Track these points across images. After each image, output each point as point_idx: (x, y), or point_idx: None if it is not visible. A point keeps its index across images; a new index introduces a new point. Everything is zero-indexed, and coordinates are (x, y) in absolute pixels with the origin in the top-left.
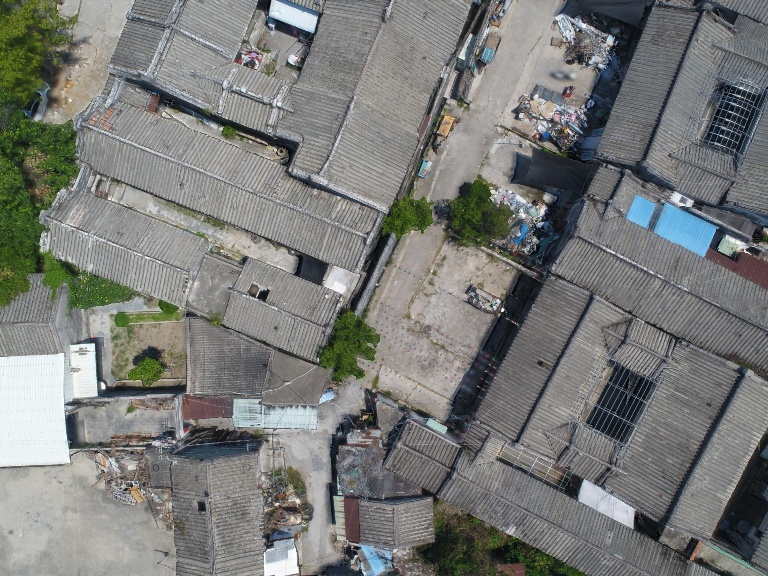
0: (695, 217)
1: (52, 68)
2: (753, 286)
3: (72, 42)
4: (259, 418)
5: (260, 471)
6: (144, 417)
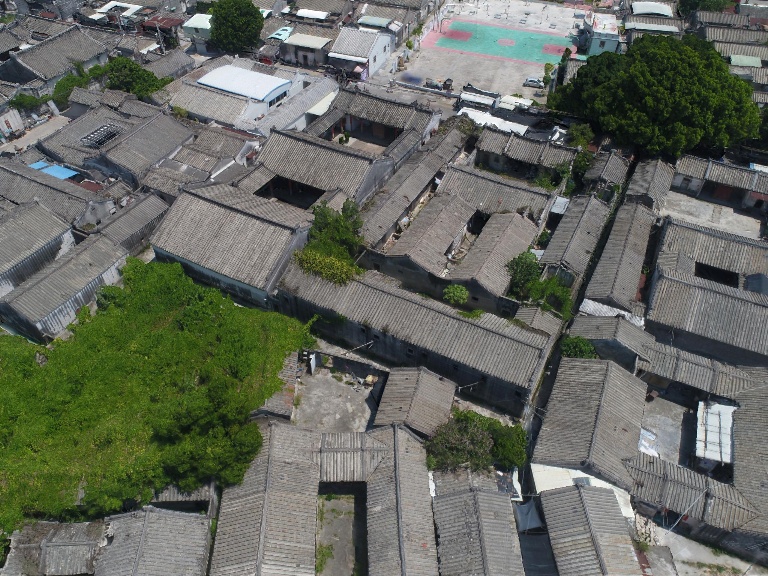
0: (68, 169)
1: None
2: (79, 187)
3: None
4: None
5: None
6: None
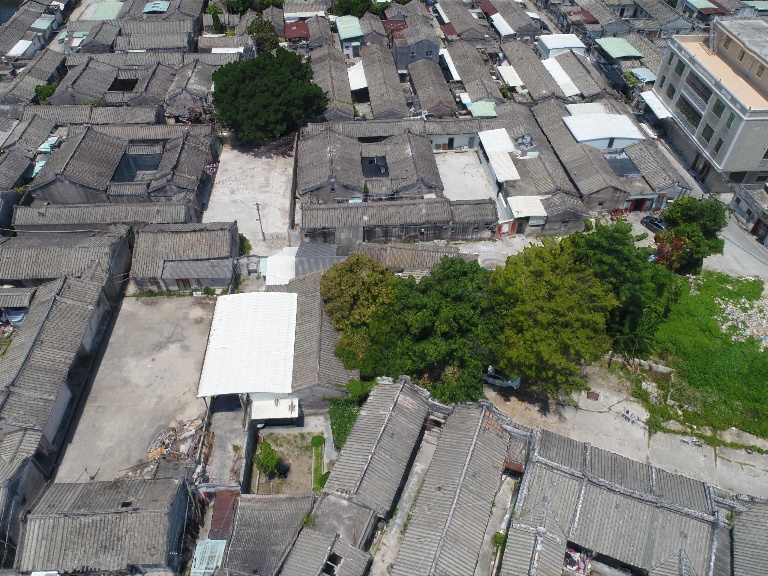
0: None
1: (533, 390)
2: None
3: (558, 405)
4: (202, 567)
5: (146, 572)
6: (227, 459)
